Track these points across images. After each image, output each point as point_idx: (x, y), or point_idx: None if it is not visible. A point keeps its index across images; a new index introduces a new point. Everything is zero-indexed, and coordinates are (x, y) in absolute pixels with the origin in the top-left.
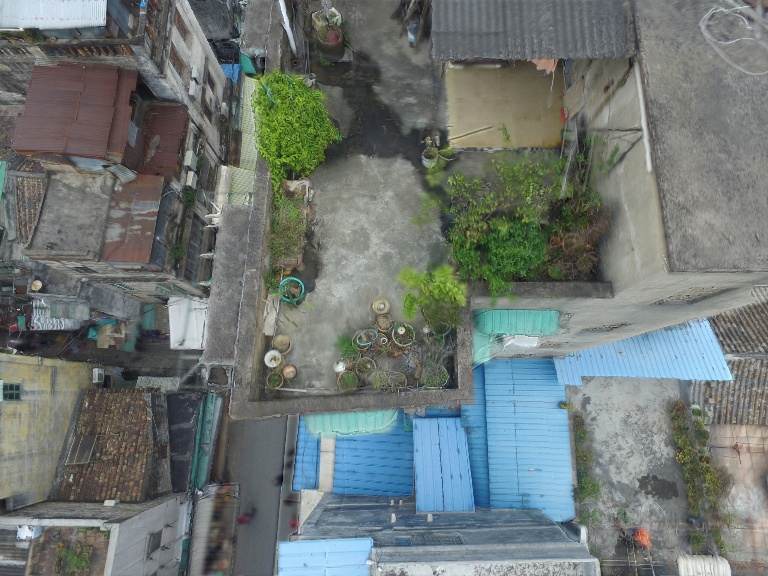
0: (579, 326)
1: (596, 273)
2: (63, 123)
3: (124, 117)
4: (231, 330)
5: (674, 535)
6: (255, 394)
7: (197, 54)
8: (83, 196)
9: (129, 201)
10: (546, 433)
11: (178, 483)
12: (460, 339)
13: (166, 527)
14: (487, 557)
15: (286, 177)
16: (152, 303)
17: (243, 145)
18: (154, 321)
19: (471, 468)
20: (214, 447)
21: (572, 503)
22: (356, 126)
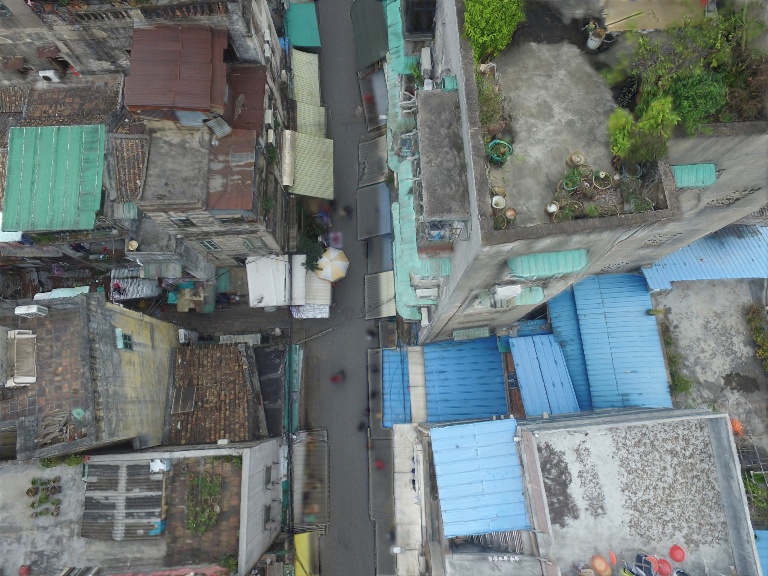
0: (712, 195)
1: (760, 118)
2: (168, 79)
3: (220, 73)
4: (447, 190)
5: (761, 424)
6: (497, 225)
7: (264, 20)
8: (184, 151)
9: (226, 154)
10: (638, 339)
11: (273, 429)
12: (662, 171)
13: (274, 464)
14: (628, 421)
15: (478, 59)
16: (226, 266)
17: (298, 113)
18: (229, 284)
19: (570, 376)
20: (300, 396)
21: (669, 398)
22: (522, 19)
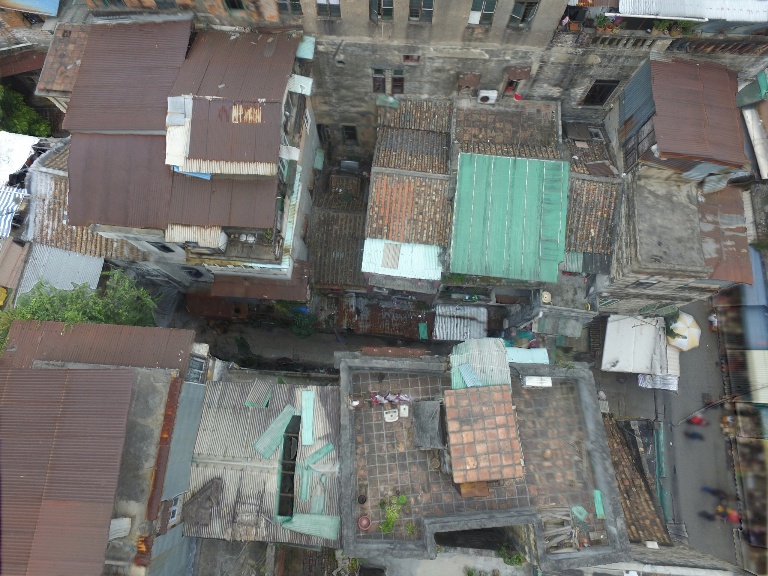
0: None
1: None
2: (698, 125)
3: None
4: None
5: None
6: None
7: None
8: (672, 205)
9: (714, 213)
10: None
11: None
12: None
13: None
14: None
15: None
16: None
17: None
18: (564, 337)
19: None
20: None
21: None
22: None
